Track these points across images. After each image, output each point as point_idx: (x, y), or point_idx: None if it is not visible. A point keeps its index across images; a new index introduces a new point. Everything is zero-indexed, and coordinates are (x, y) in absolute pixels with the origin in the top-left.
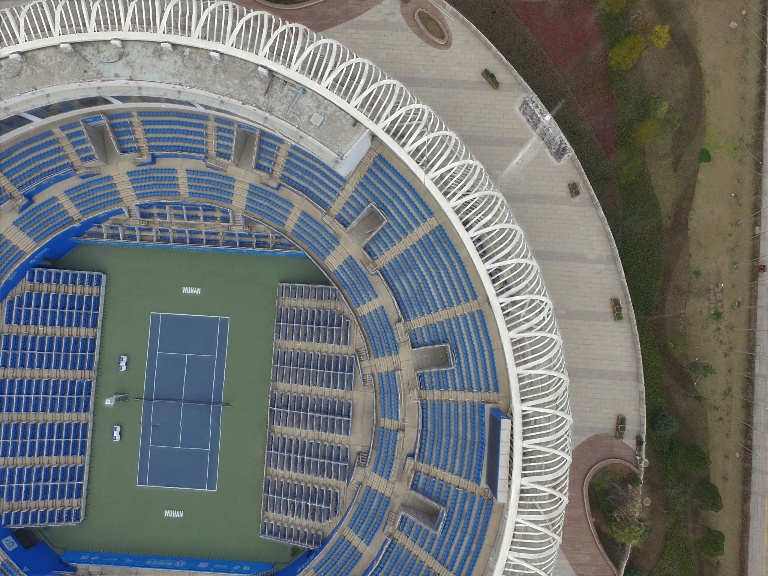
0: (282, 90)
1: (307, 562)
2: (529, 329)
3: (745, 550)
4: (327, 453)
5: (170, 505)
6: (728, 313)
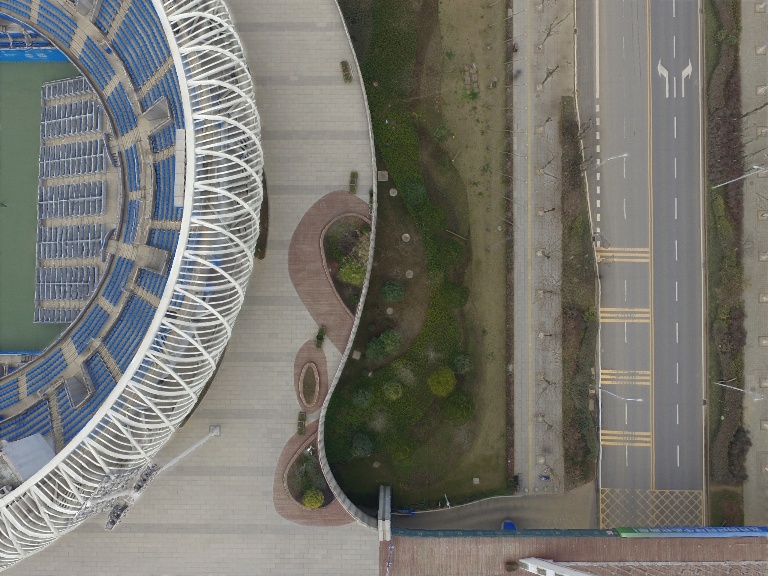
0: None
1: None
2: (198, 44)
3: (510, 318)
4: (85, 233)
5: None
6: (484, 93)
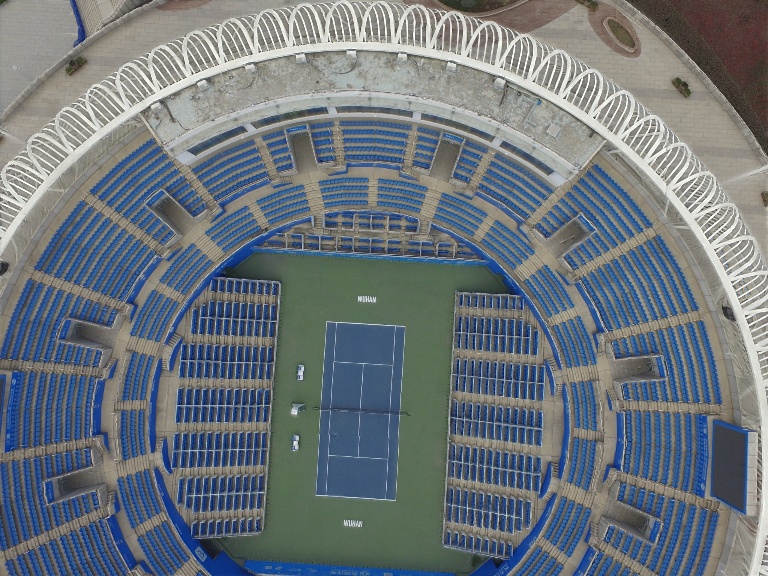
0: (516, 101)
1: (501, 573)
2: None
3: None
4: (517, 463)
5: (349, 515)
6: None
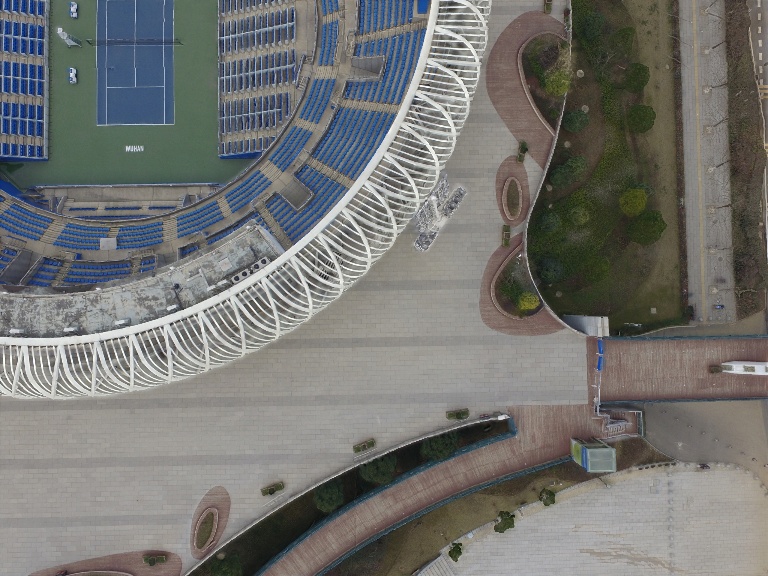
0: None
1: None
2: None
3: (680, 153)
4: (275, 61)
5: (131, 141)
6: None
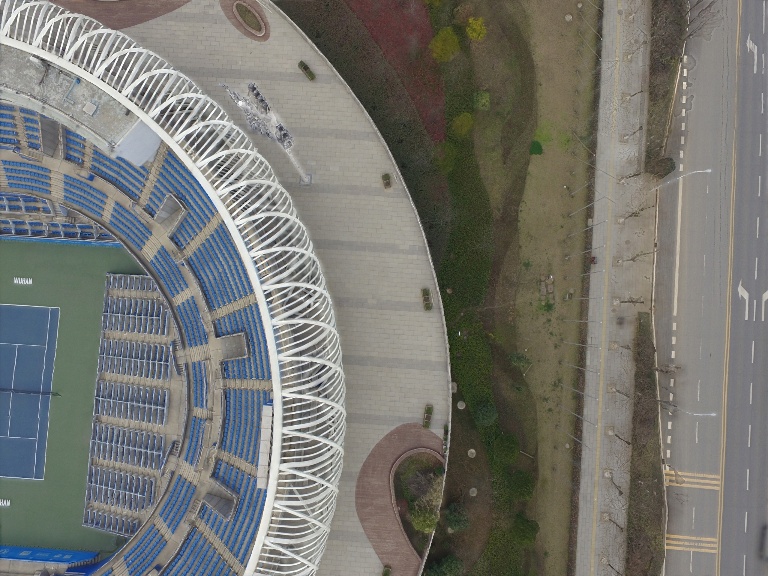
0: (57, 79)
1: (119, 550)
2: (292, 316)
3: (573, 541)
4: (144, 442)
5: None
6: (559, 305)
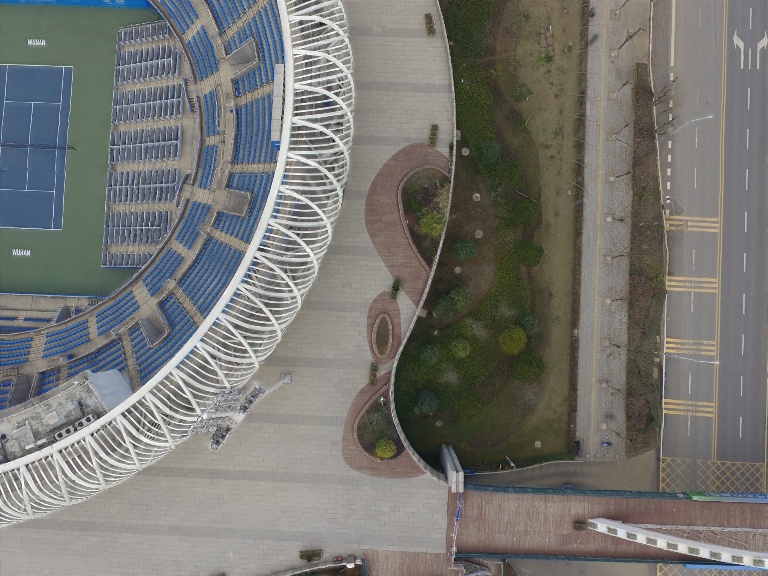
0: None
1: None
2: None
3: (577, 283)
4: (159, 177)
5: (18, 245)
6: (559, 56)
